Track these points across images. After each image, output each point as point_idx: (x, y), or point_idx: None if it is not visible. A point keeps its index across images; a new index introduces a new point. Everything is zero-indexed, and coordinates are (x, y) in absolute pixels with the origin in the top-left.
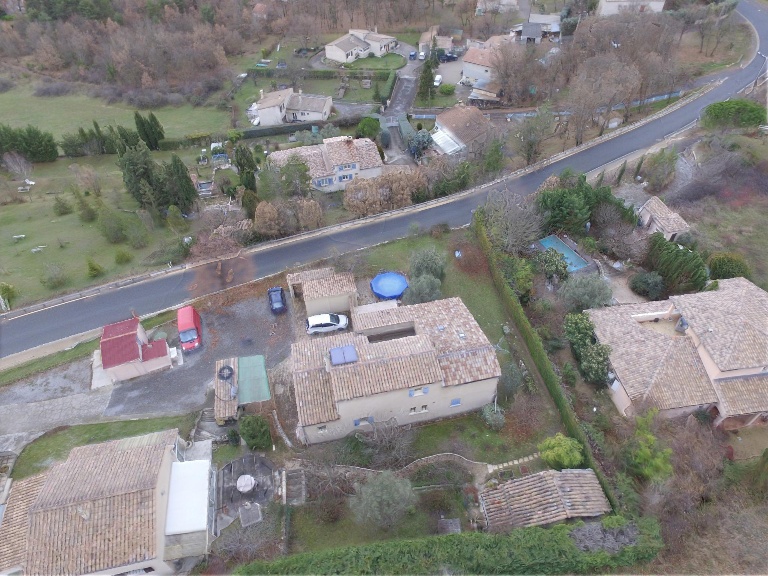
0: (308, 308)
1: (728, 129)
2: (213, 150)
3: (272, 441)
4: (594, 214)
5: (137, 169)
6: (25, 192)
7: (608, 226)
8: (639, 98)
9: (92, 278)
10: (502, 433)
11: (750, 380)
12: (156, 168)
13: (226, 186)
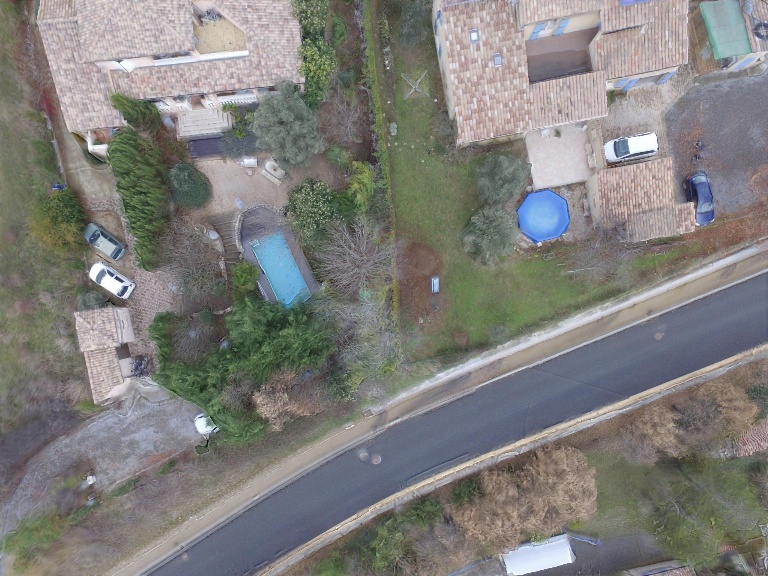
0: None
1: None
2: None
3: None
4: None
5: None
6: None
7: None
8: None
9: None
10: None
11: None
12: None
13: None
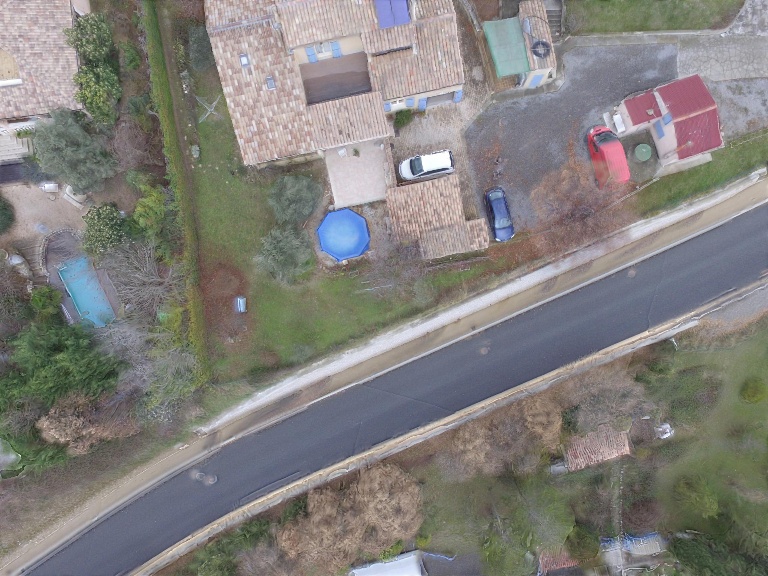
0: None
1: None
2: None
3: None
4: None
5: None
6: None
7: None
8: None
9: None
10: None
11: None
12: None
13: None
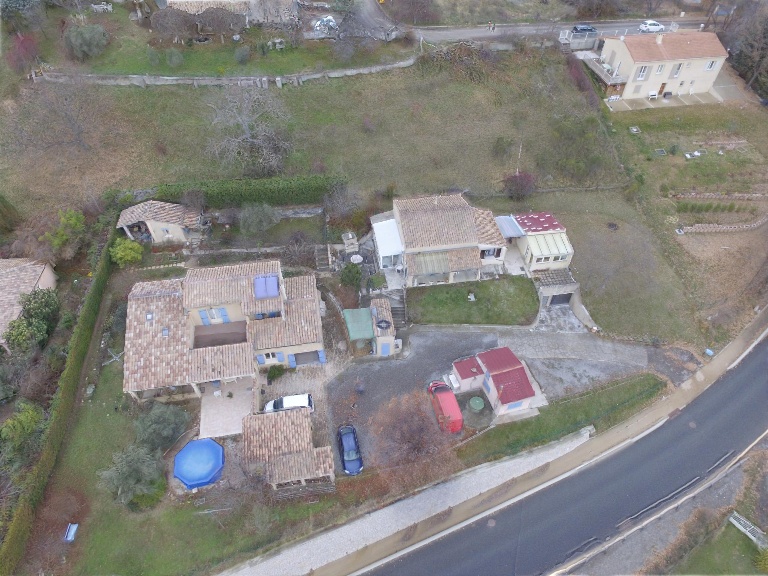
0: None
1: None
2: None
3: None
4: None
5: None
6: None
7: None
8: None
9: None
10: None
11: None
12: None
13: None
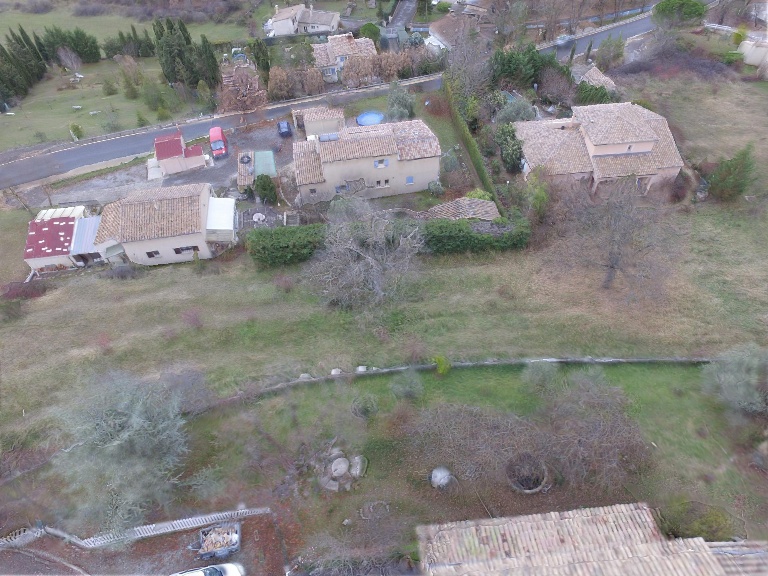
0: (307, 130)
1: (675, 24)
2: (234, 53)
3: (278, 201)
4: (540, 76)
5: (172, 51)
6: (76, 83)
7: (550, 85)
8: (615, 11)
9: (140, 127)
10: (441, 198)
11: (618, 157)
12: (187, 52)
13: (245, 77)
